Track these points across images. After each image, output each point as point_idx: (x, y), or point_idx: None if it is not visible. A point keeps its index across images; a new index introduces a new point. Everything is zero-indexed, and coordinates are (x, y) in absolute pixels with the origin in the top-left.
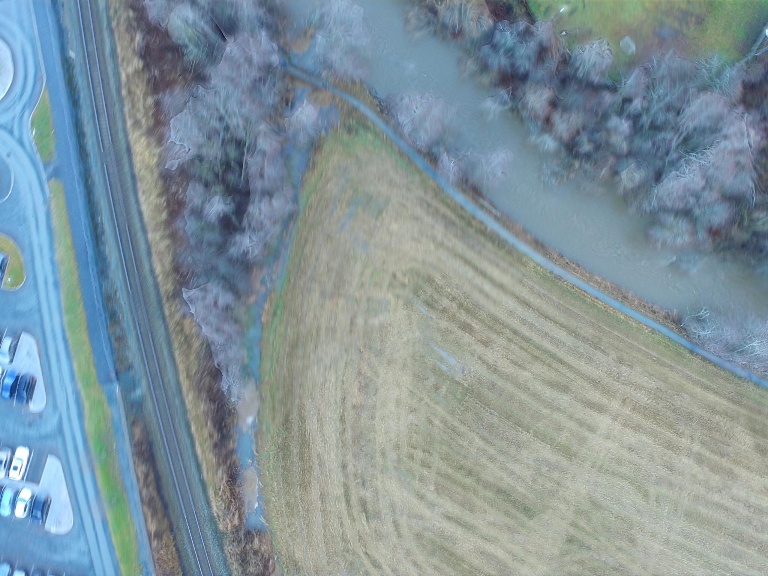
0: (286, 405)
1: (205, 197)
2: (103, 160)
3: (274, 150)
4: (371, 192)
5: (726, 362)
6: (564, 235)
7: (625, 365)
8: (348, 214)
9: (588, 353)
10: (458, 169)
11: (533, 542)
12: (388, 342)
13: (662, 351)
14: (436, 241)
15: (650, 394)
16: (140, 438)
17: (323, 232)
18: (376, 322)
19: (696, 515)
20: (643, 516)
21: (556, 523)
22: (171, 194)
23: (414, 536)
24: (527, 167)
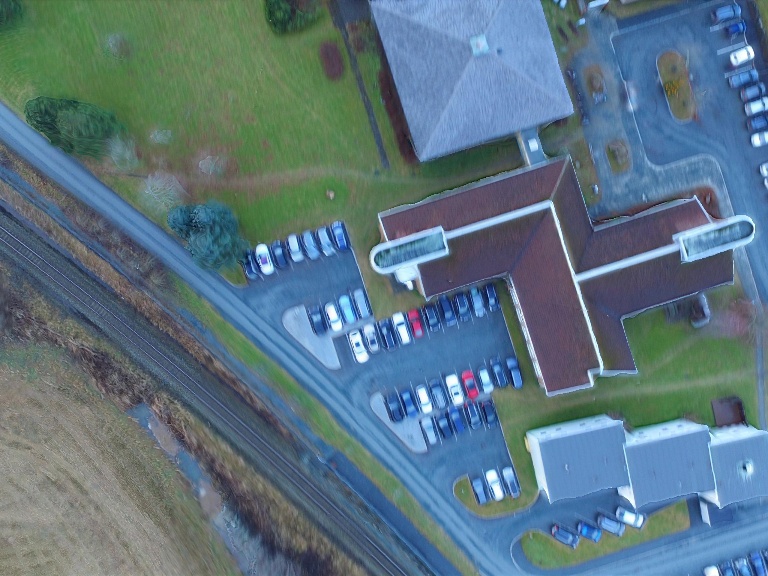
0: (181, 526)
1: None
2: None
3: None
4: None
5: None
6: None
7: None
8: None
9: None
10: None
11: None
12: None
13: None
14: None
15: None
16: None
17: None
18: None
19: None
20: None
21: None
22: None
23: None
24: None
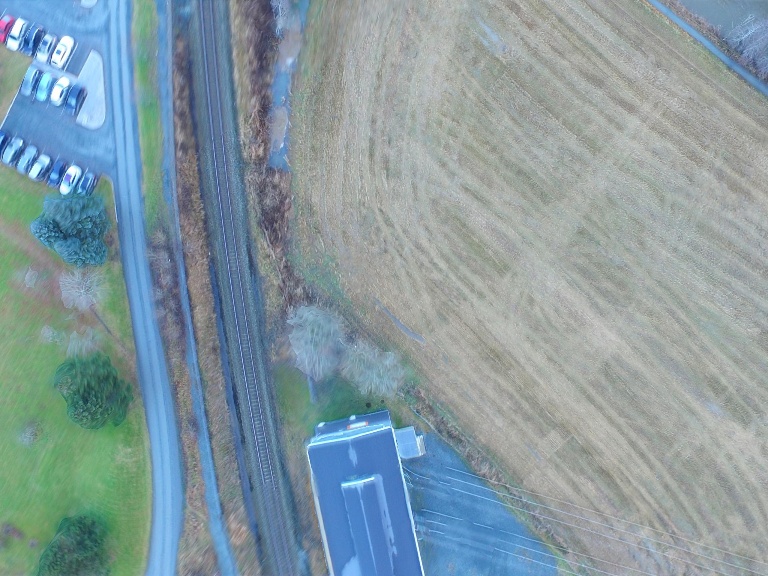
0: (327, 51)
1: None
2: None
3: None
4: None
5: (761, 84)
6: None
7: (662, 70)
8: None
9: (628, 52)
10: None
11: (545, 227)
12: (436, 9)
13: (701, 62)
14: None
15: (682, 102)
16: (182, 53)
17: None
18: None
19: (708, 229)
20: (656, 221)
21: (570, 213)
22: None
23: (430, 201)
24: None
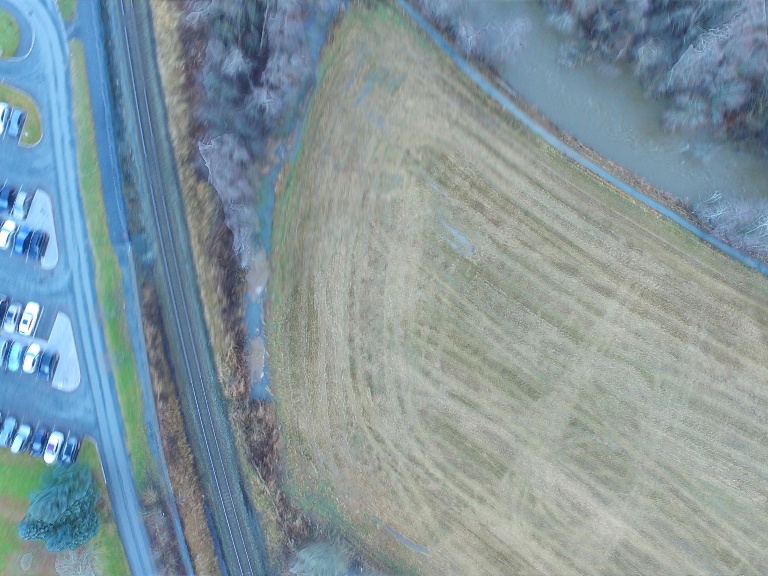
0: (296, 276)
1: (224, 55)
2: (124, 23)
3: (295, 9)
4: (388, 68)
5: (736, 251)
6: (579, 118)
7: (635, 250)
8: (364, 89)
9: (598, 237)
10: (476, 44)
11: (537, 423)
12: (399, 218)
13: (672, 238)
14: (451, 119)
15: (659, 280)
16: (150, 301)
17: (339, 106)
18: (388, 197)
19: (700, 403)
20: (647, 402)
21: (560, 405)
22: (190, 58)
23: (418, 412)
24: (544, 48)
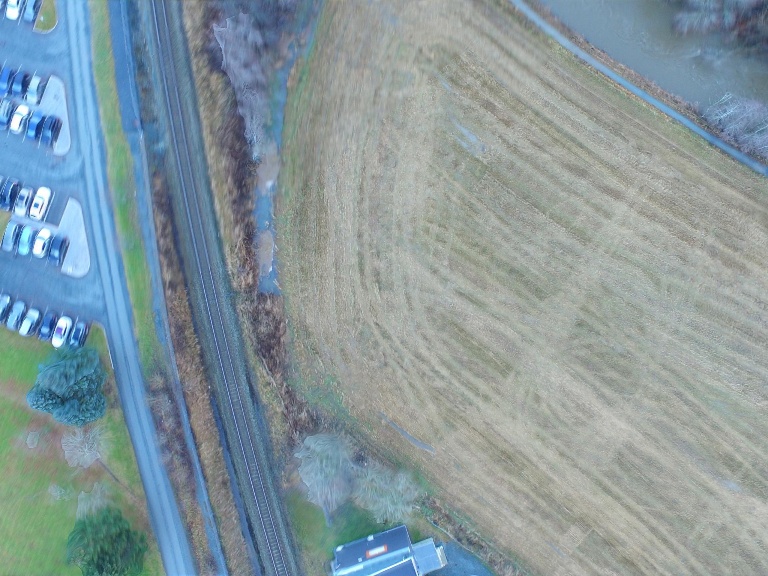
0: (306, 170)
1: None
2: None
3: None
4: None
5: (745, 156)
6: (591, 20)
7: (644, 153)
8: None
9: (608, 139)
10: None
11: (543, 323)
12: (411, 116)
13: (682, 141)
14: (464, 18)
15: (667, 183)
16: (160, 190)
17: (353, 2)
18: (400, 95)
19: (706, 307)
20: (654, 305)
21: (567, 306)
22: None
23: (425, 310)
24: None
